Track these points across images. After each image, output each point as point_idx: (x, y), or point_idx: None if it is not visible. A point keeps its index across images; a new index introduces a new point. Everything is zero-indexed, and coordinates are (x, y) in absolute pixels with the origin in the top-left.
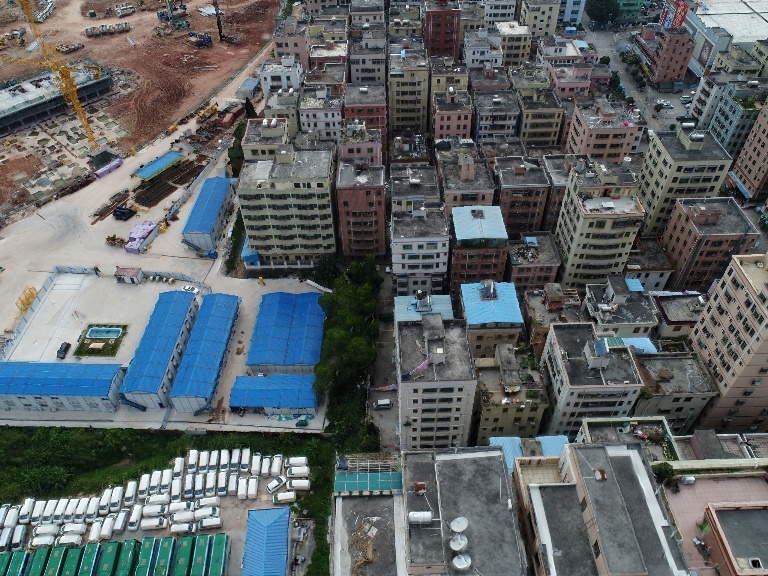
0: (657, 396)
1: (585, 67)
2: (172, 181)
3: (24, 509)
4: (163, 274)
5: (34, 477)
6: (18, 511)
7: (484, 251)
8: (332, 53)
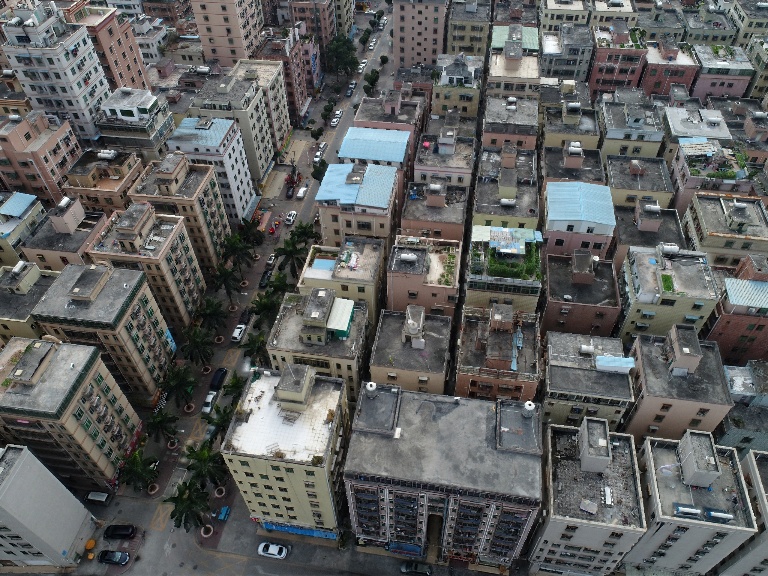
0: (169, 51)
1: None
2: None
3: None
4: None
5: None
6: None
7: (160, 5)
8: None
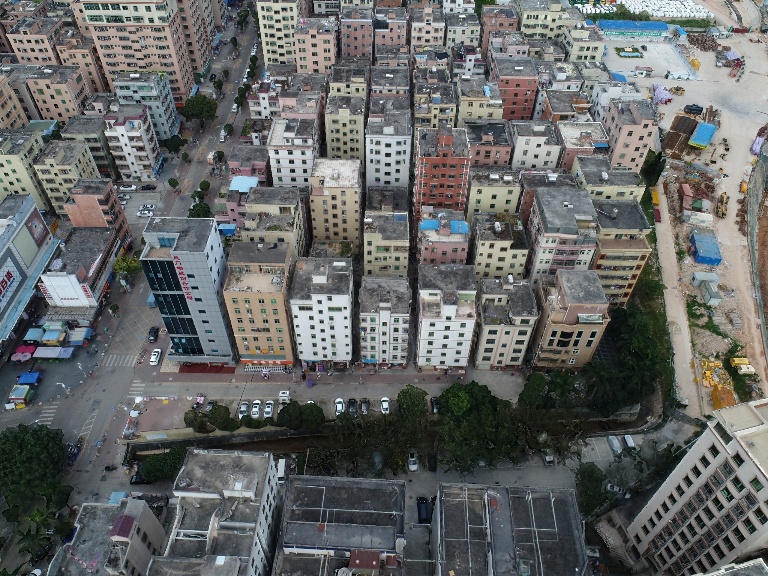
0: None
1: (287, 93)
2: (682, 135)
3: (603, 9)
4: (621, 72)
5: (607, 13)
6: (604, 9)
7: None
8: (578, 133)
